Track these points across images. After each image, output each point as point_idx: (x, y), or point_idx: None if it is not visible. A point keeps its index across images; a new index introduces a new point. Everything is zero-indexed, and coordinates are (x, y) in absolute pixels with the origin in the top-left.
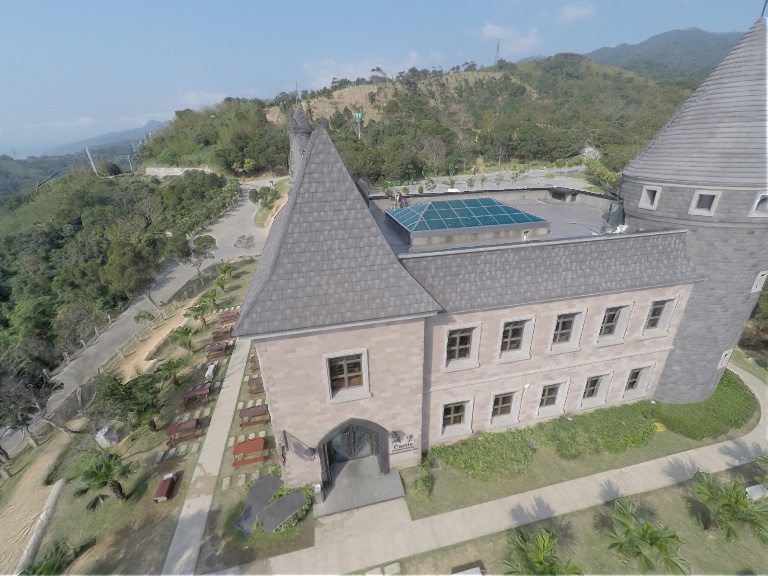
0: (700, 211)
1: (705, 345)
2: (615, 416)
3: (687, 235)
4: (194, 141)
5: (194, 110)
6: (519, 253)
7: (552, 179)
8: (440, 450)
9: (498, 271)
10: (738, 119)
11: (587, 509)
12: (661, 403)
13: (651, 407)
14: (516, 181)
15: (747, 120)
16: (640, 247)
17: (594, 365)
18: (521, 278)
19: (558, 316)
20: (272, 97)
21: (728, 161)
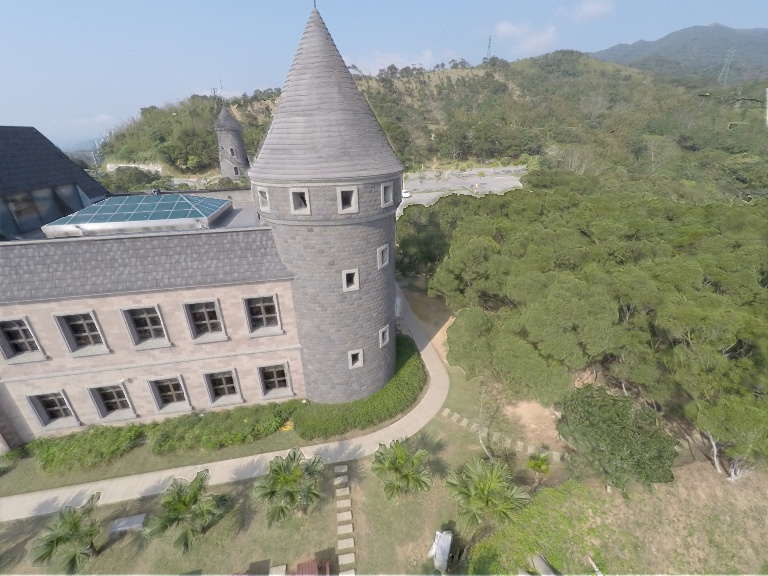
0: (265, 208)
1: (322, 344)
2: (247, 414)
3: (272, 232)
4: (150, 138)
5: (158, 108)
6: (62, 248)
7: (492, 178)
8: (42, 441)
9: (38, 265)
10: (284, 115)
11: (116, 503)
12: (310, 402)
13: (295, 406)
14: (440, 179)
15: (289, 116)
16: (216, 244)
17: (205, 362)
18: (67, 272)
19: (123, 311)
20: (239, 95)
21: (271, 157)
